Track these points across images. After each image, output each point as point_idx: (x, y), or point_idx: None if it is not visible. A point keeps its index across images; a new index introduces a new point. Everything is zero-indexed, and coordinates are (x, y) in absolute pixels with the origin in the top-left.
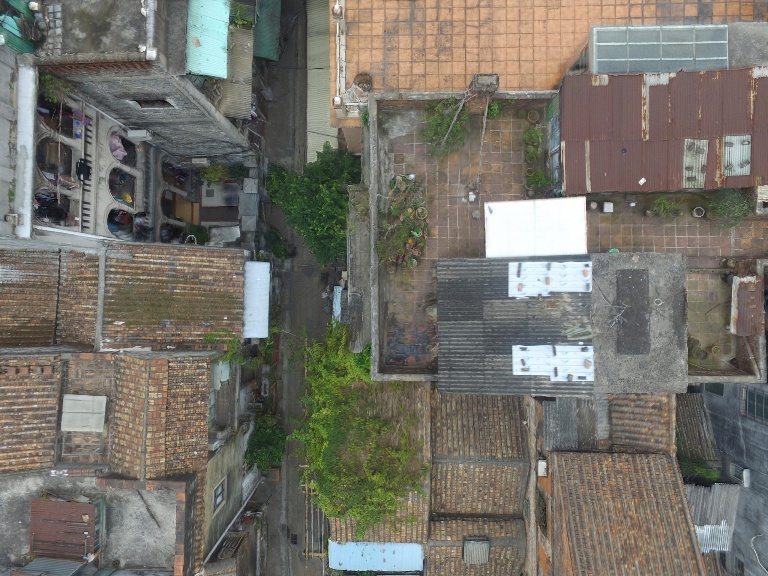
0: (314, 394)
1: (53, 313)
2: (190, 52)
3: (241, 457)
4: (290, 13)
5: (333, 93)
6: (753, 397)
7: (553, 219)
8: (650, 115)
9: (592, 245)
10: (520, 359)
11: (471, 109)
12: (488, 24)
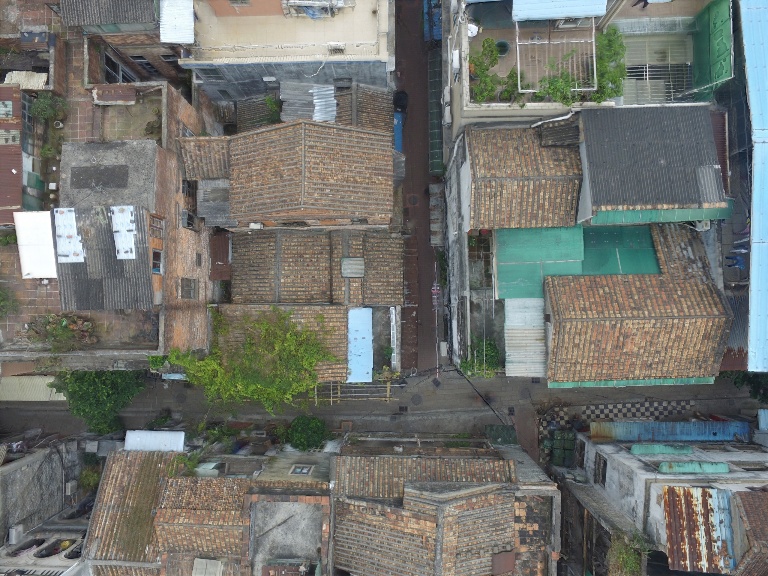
0: None
1: None
2: None
3: (300, 453)
4: None
5: None
6: None
7: (30, 233)
8: None
9: None
10: (124, 254)
11: None
12: None
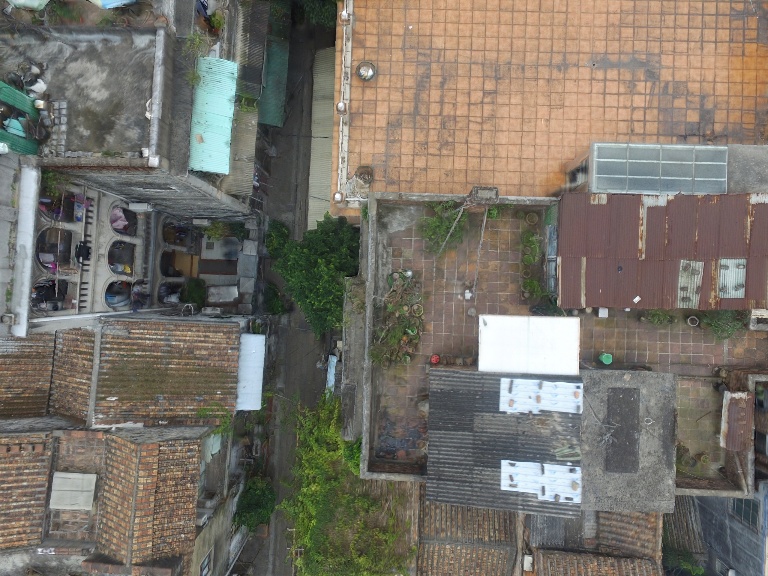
0: (304, 467)
1: (47, 383)
2: (193, 149)
3: (229, 521)
4: (297, 75)
5: (334, 182)
6: (741, 499)
7: (547, 337)
8: (647, 235)
9: (586, 348)
10: (508, 475)
11: (470, 210)
12: (491, 120)
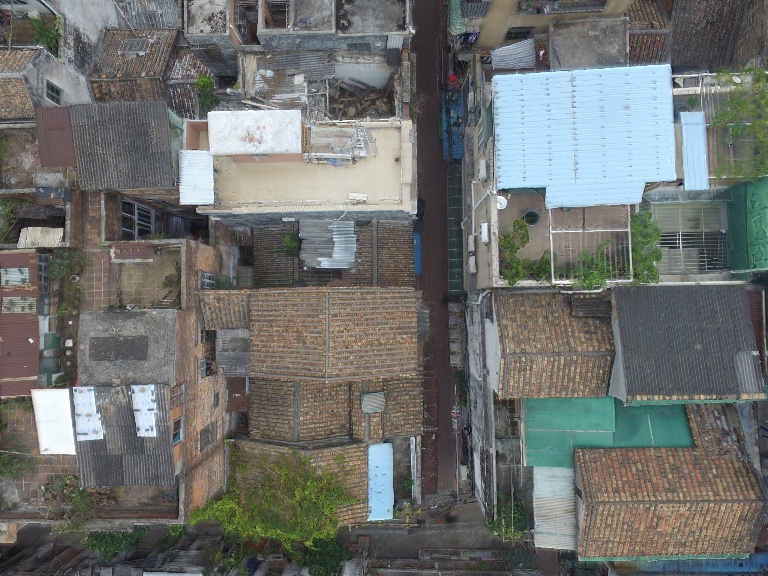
0: None
1: None
2: None
3: None
4: None
5: None
6: None
7: (48, 409)
8: None
9: None
10: (145, 432)
11: None
12: None
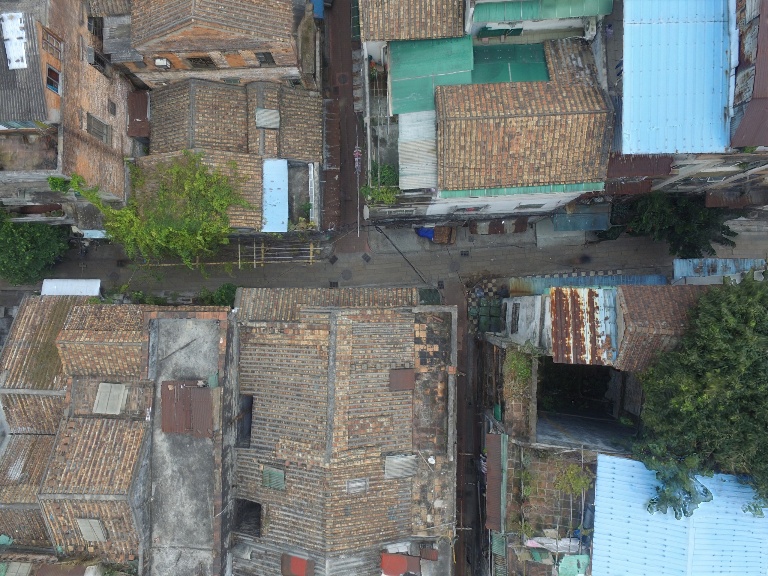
0: None
1: None
2: None
3: None
4: None
5: None
6: None
7: None
8: None
9: None
10: (16, 63)
11: None
12: None
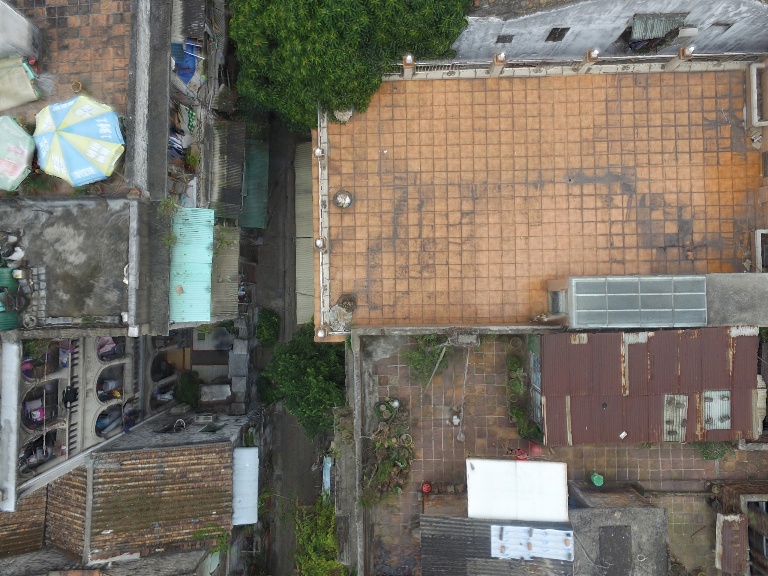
0: None
1: (42, 515)
2: (173, 302)
3: None
4: (278, 168)
5: (318, 309)
6: None
7: (534, 481)
8: (630, 371)
9: (577, 468)
10: None
11: None
12: (470, 241)
